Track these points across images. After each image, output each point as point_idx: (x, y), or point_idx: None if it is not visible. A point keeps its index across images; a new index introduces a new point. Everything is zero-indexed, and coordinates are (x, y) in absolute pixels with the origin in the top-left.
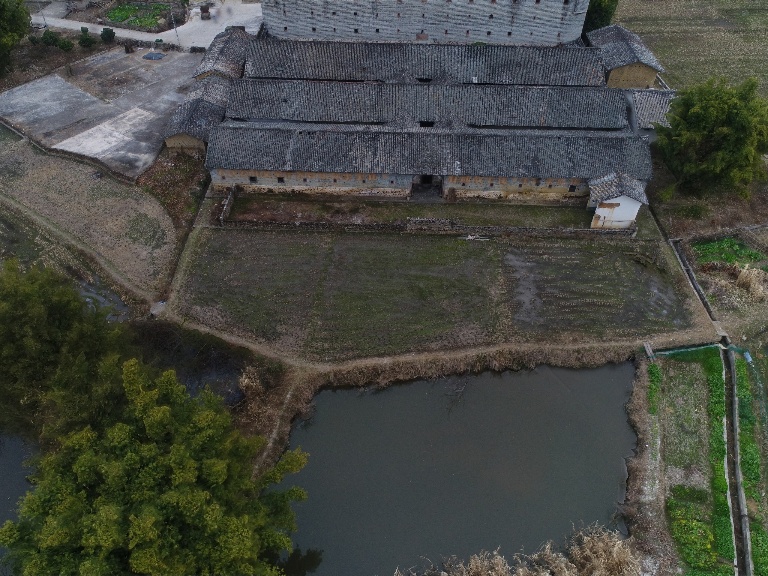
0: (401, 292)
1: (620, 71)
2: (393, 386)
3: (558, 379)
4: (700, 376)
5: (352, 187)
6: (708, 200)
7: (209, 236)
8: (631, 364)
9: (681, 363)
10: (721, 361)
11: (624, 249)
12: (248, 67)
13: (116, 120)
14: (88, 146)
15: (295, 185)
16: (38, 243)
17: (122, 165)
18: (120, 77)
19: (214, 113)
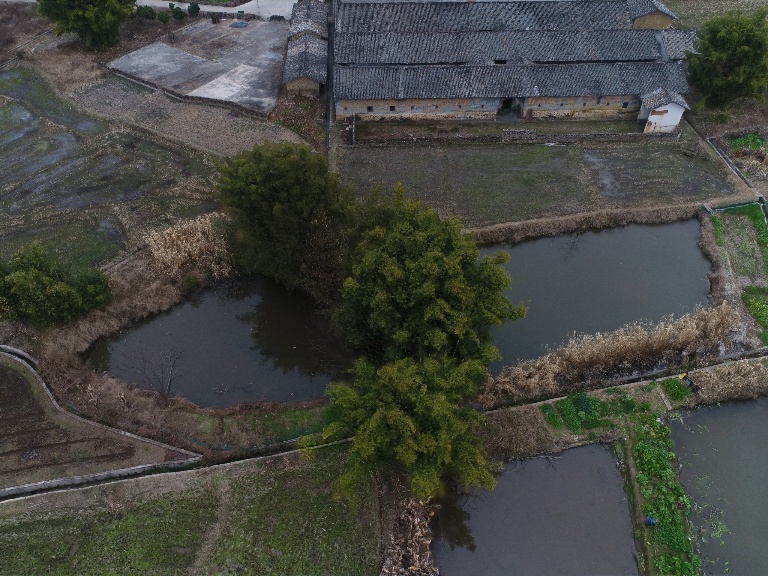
0: (511, 182)
1: (642, 19)
2: (523, 243)
3: (645, 231)
4: (748, 223)
5: (450, 112)
6: (729, 111)
7: (345, 152)
8: (696, 219)
9: (733, 215)
10: (762, 212)
11: (673, 147)
12: (338, 26)
13: (230, 74)
14: (215, 94)
15: (403, 112)
16: (206, 164)
17: (251, 106)
18: (218, 42)
19: (320, 62)
